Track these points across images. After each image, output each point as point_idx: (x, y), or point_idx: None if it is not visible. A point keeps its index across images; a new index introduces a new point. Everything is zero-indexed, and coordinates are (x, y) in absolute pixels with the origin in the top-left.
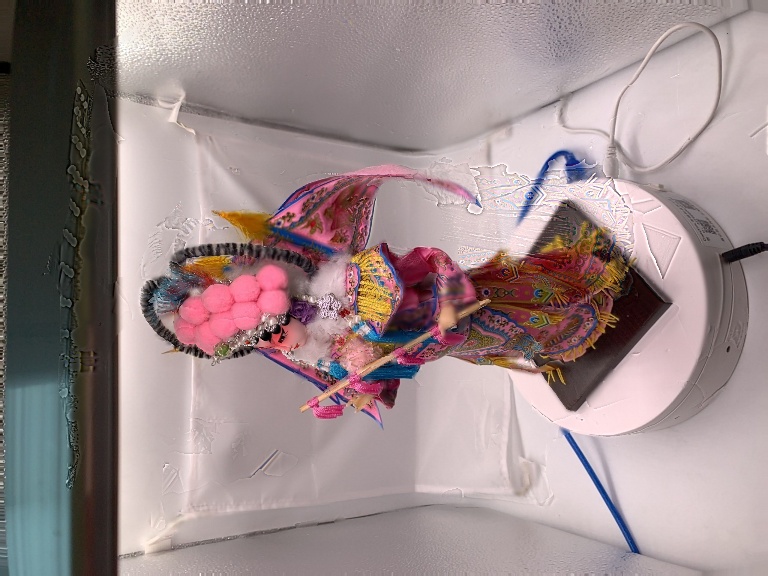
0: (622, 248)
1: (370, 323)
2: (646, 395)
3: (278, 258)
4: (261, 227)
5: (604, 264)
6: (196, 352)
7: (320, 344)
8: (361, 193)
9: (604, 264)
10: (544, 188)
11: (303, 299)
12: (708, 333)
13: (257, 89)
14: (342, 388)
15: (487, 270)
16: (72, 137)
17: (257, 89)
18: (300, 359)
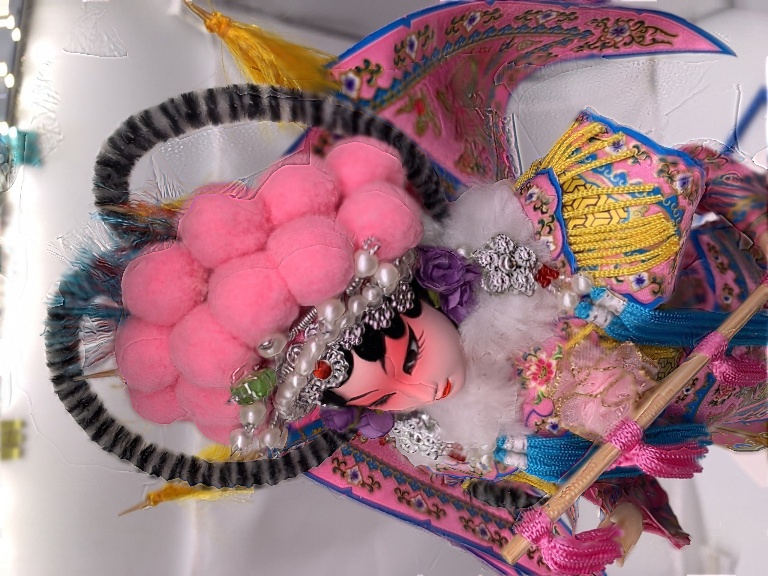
0: None
1: (614, 289)
2: None
3: (366, 133)
4: (312, 71)
5: None
6: (197, 480)
7: (498, 381)
8: (487, 96)
9: None
10: None
11: None
12: None
13: None
14: (604, 468)
15: None
16: None
17: None
18: (456, 436)
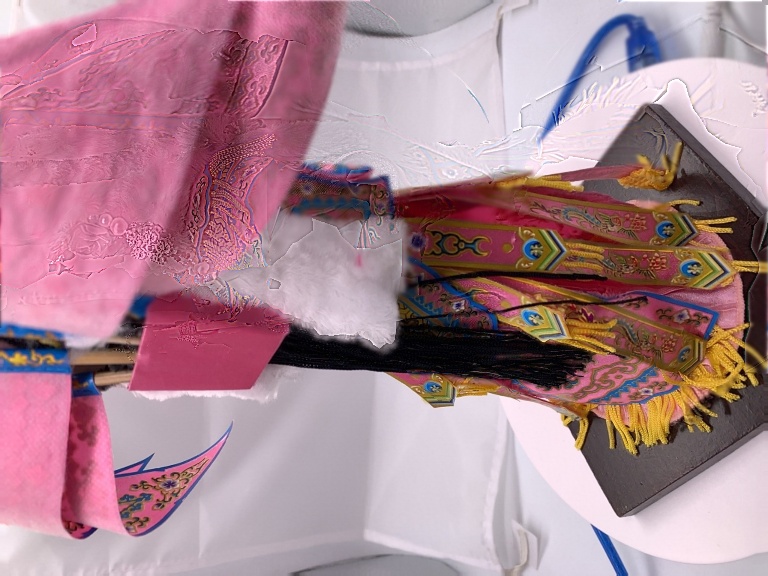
0: (679, 412)
1: None
2: None
3: (19, 184)
4: None
5: (633, 401)
6: None
7: None
8: None
9: (633, 401)
10: (576, 312)
11: (101, 224)
12: (766, 355)
13: None
14: None
15: (479, 182)
16: None
17: None
18: None
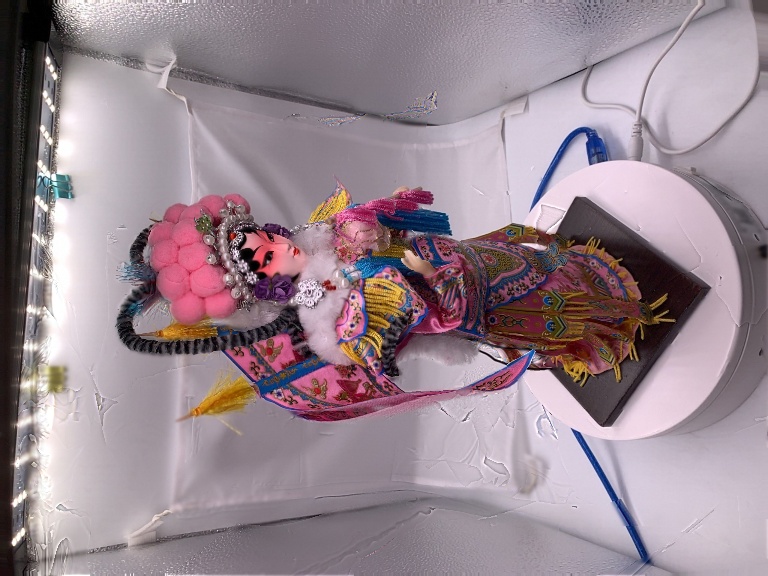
0: None
1: None
2: (669, 201)
3: None
4: None
5: None
6: (210, 343)
7: None
8: None
9: None
10: None
11: None
12: None
13: (249, 572)
14: None
15: None
16: (29, 518)
17: (249, 572)
18: (317, 268)
